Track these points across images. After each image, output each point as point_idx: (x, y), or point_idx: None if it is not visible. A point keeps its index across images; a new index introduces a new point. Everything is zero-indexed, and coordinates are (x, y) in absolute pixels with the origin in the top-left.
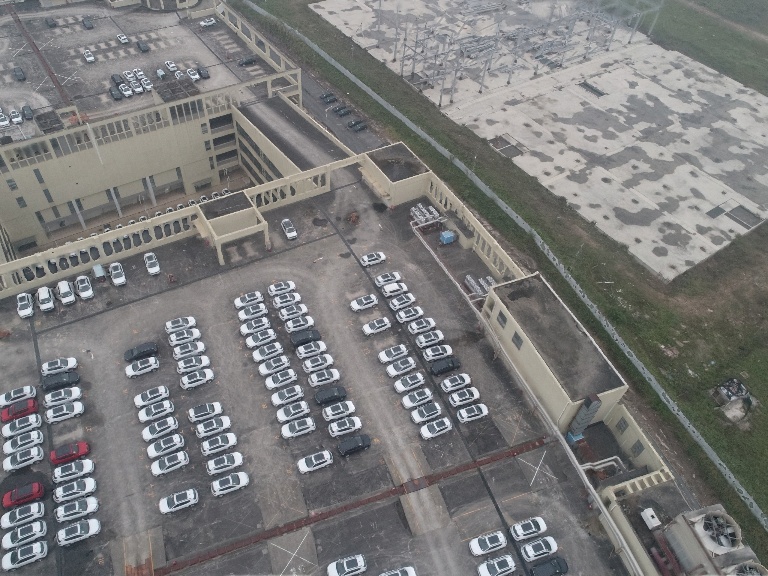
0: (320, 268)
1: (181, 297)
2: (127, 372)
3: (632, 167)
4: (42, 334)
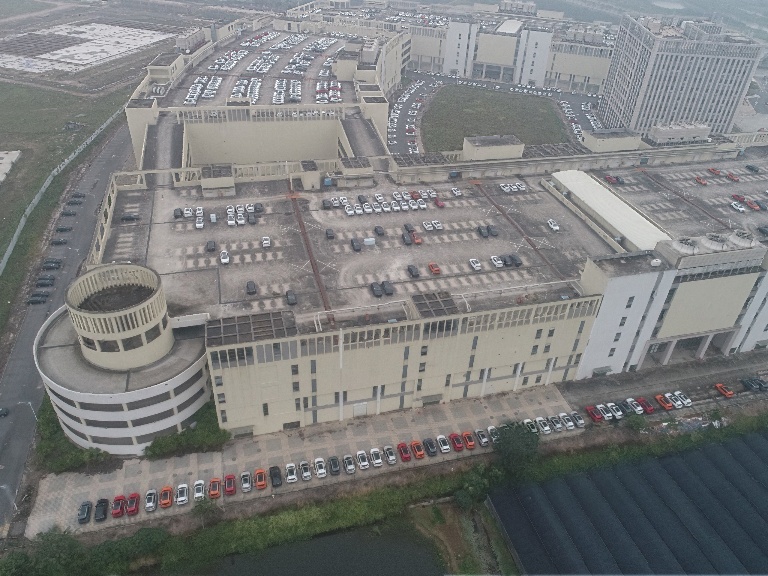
0: None
1: None
2: None
3: None
4: None
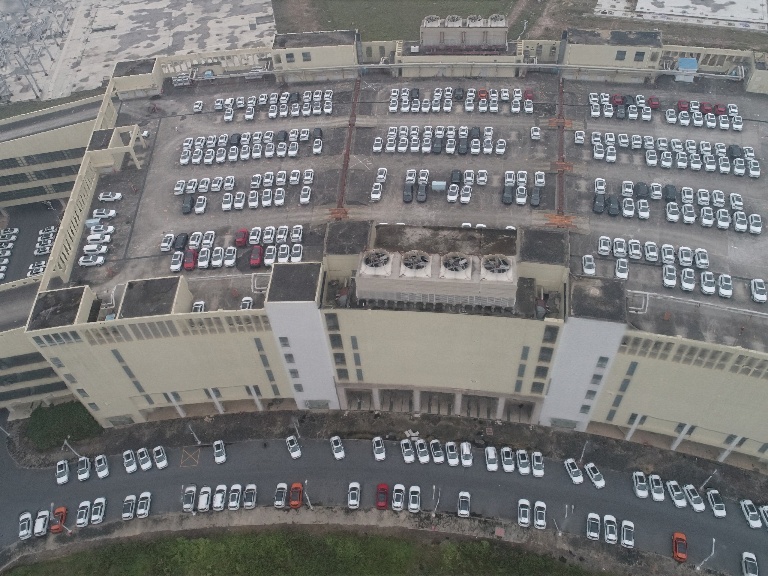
0: (184, 129)
1: (153, 189)
2: (200, 210)
3: (190, 40)
4: (127, 255)
